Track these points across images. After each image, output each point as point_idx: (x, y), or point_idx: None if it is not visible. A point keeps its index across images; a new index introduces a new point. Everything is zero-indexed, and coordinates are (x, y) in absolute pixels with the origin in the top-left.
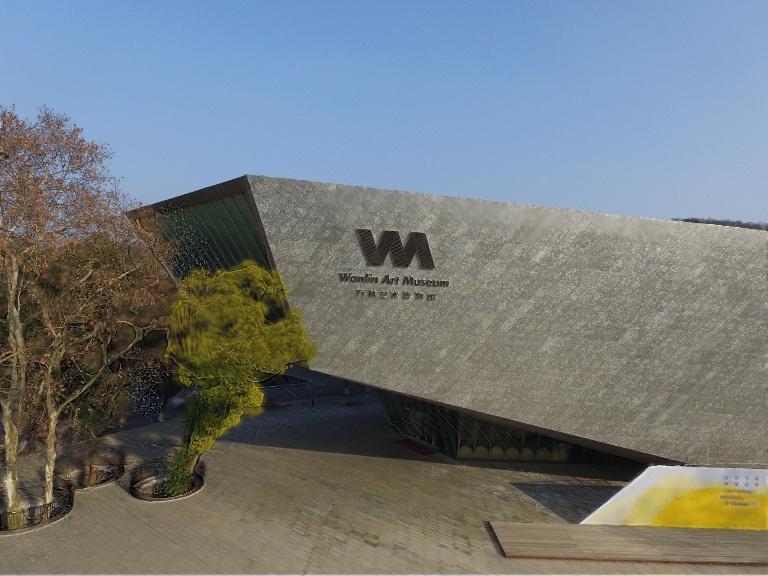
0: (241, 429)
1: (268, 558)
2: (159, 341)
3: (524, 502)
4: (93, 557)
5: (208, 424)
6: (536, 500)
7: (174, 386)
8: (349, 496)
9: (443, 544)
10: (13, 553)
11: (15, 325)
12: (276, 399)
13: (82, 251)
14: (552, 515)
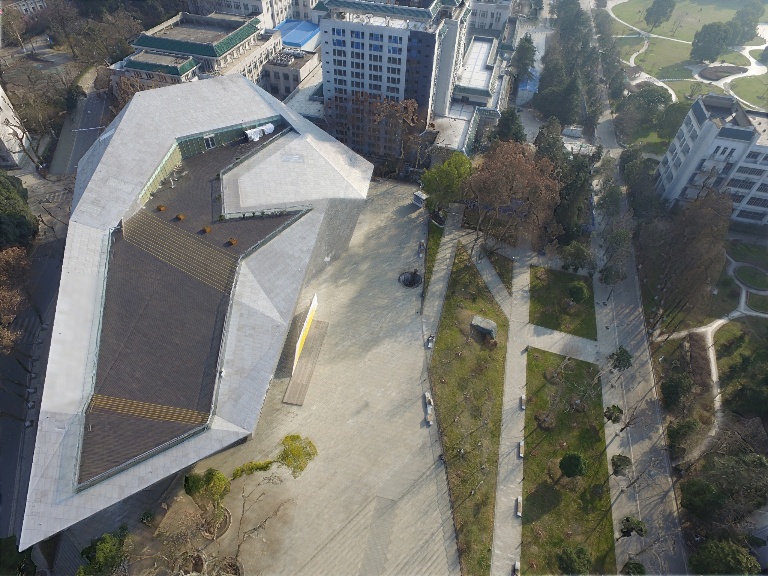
0: (132, 500)
1: (284, 474)
2: (11, 566)
3: (272, 384)
4: (269, 532)
5: (229, 492)
6: (272, 380)
7: (31, 562)
8: (249, 445)
9: (291, 420)
10: (259, 562)
11: (191, 575)
12: (2, 488)
13: (87, 572)
14: (283, 380)
